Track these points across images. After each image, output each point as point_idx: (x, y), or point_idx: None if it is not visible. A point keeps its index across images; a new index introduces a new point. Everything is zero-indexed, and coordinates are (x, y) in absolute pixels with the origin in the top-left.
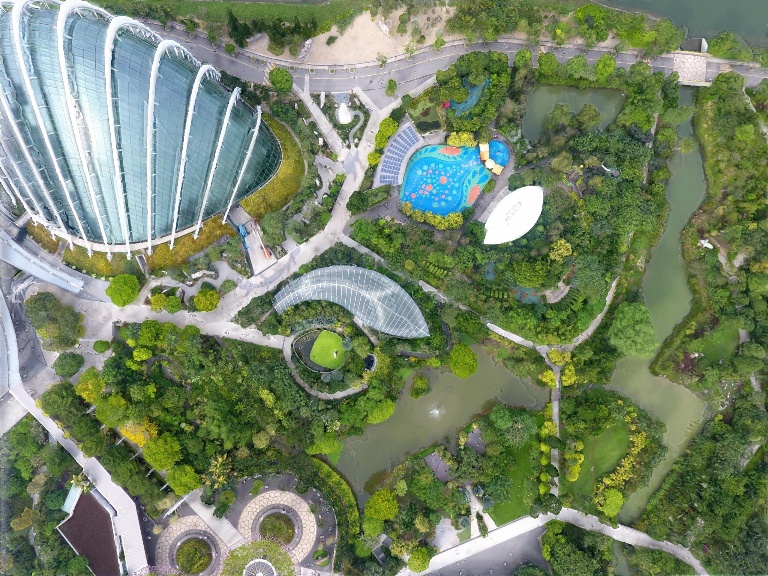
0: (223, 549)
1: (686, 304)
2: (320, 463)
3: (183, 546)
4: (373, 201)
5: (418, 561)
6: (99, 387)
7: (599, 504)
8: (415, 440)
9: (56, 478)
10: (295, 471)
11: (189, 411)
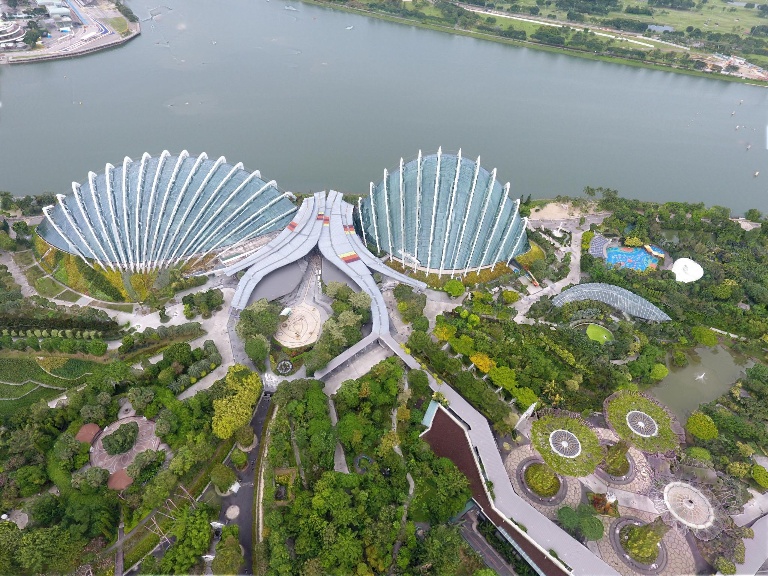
0: None
1: None
2: None
3: (530, 468)
4: (595, 262)
5: (763, 472)
6: None
7: None
8: (694, 402)
9: (414, 400)
10: None
11: (513, 358)
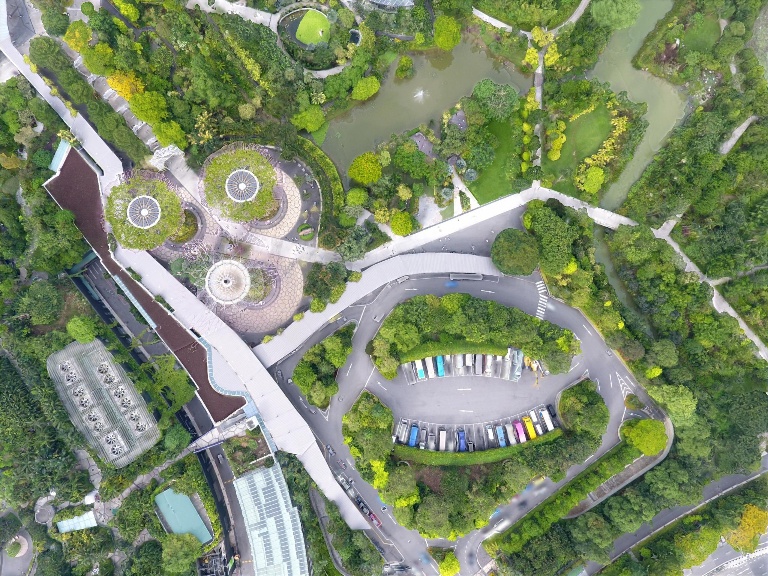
0: (209, 221)
1: (669, 2)
2: (305, 138)
3: None
4: None
5: (401, 221)
6: (86, 35)
7: (580, 183)
8: (400, 127)
9: (43, 138)
10: (280, 134)
11: (175, 74)
